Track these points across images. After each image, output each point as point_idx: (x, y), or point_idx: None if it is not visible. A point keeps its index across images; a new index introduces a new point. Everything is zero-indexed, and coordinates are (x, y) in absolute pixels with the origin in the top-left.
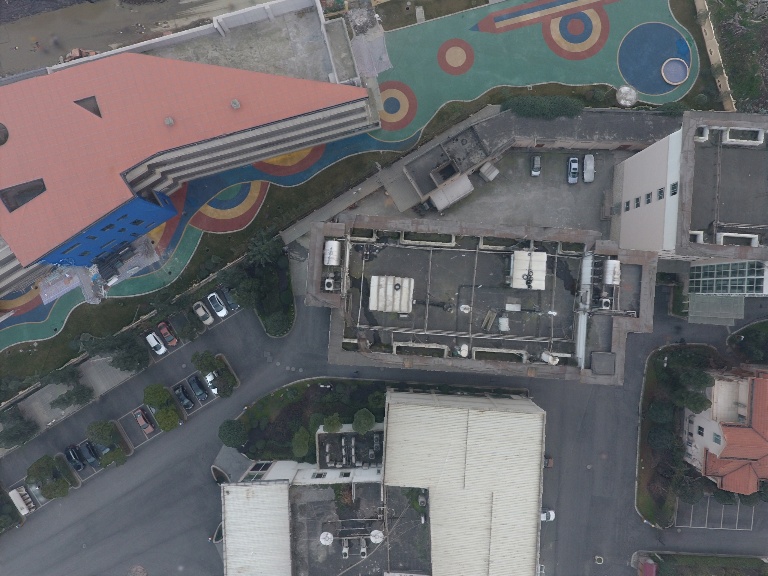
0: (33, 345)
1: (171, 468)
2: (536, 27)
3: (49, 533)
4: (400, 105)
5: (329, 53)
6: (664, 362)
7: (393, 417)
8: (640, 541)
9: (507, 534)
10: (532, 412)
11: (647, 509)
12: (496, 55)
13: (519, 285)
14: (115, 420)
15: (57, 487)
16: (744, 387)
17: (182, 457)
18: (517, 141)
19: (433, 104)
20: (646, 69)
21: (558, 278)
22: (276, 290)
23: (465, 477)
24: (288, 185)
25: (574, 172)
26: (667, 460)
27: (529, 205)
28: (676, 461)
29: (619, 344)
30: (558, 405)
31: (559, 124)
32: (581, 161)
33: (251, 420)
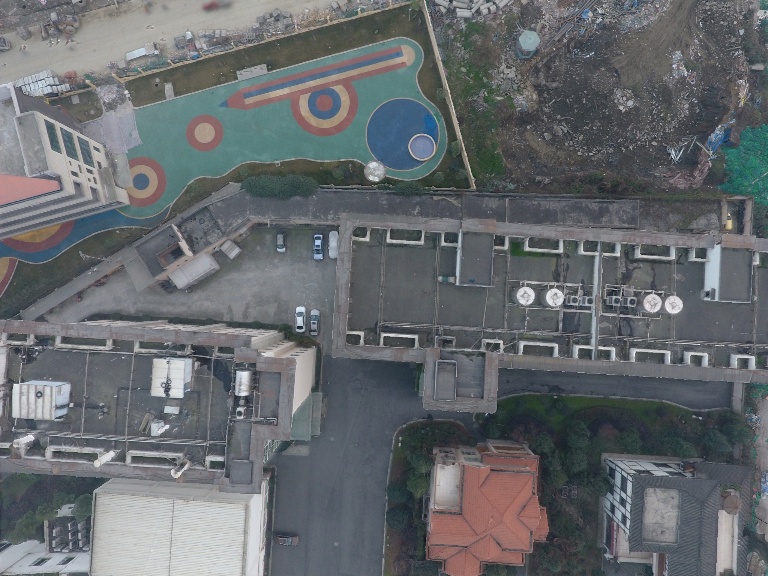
0: None
1: None
2: (285, 103)
3: None
4: (149, 181)
5: (20, 146)
6: (399, 442)
7: (100, 507)
8: None
9: None
10: (235, 502)
11: None
12: (245, 131)
13: (157, 393)
14: None
15: None
16: None
17: None
18: (255, 220)
19: (182, 180)
20: (394, 145)
21: (218, 380)
22: None
23: (170, 567)
24: (36, 262)
25: (318, 249)
26: (410, 538)
27: (277, 281)
28: (418, 539)
29: (257, 452)
30: (305, 482)
31: (294, 204)
32: (328, 237)
33: None
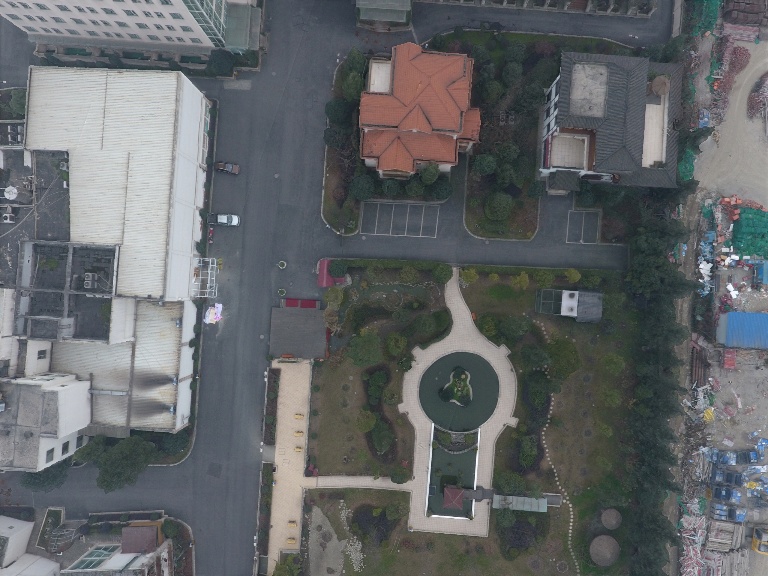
0: None
1: None
2: None
3: None
4: None
5: None
6: None
7: (35, 81)
8: (325, 248)
9: (142, 192)
10: (167, 71)
11: (332, 217)
12: None
13: None
14: None
15: None
16: None
17: None
18: None
19: None
20: None
21: None
22: None
23: (103, 138)
24: None
25: None
26: None
27: None
28: None
29: None
30: (247, 115)
31: None
32: None
33: None
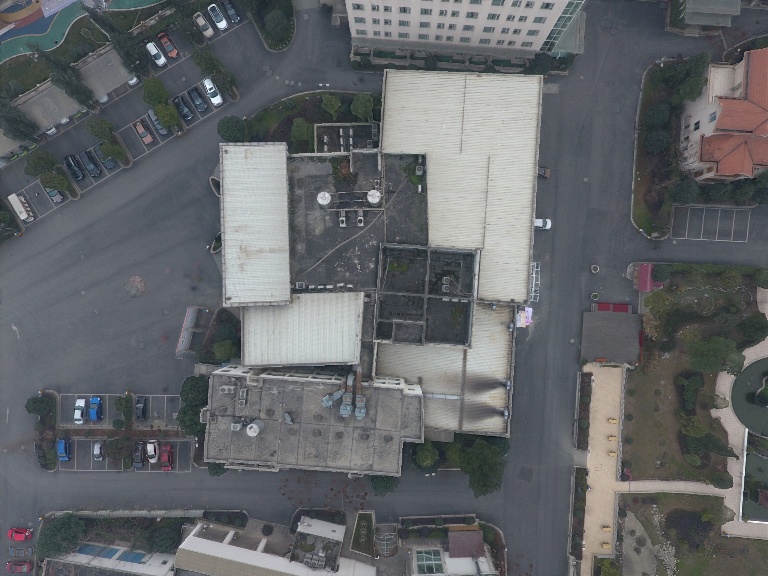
0: (34, 56)
1: (170, 180)
2: None
3: (47, 244)
4: None
5: None
6: (661, 63)
7: (391, 85)
8: (636, 252)
9: (503, 196)
10: (529, 75)
11: (643, 221)
12: None
13: None
14: (114, 132)
15: (56, 178)
16: (740, 68)
17: (181, 169)
18: None
19: None
20: None
21: None
22: (276, 2)
23: (462, 142)
24: None
25: None
26: (663, 169)
27: None
28: (672, 169)
29: None
30: (555, 119)
31: None
32: None
33: (250, 128)
